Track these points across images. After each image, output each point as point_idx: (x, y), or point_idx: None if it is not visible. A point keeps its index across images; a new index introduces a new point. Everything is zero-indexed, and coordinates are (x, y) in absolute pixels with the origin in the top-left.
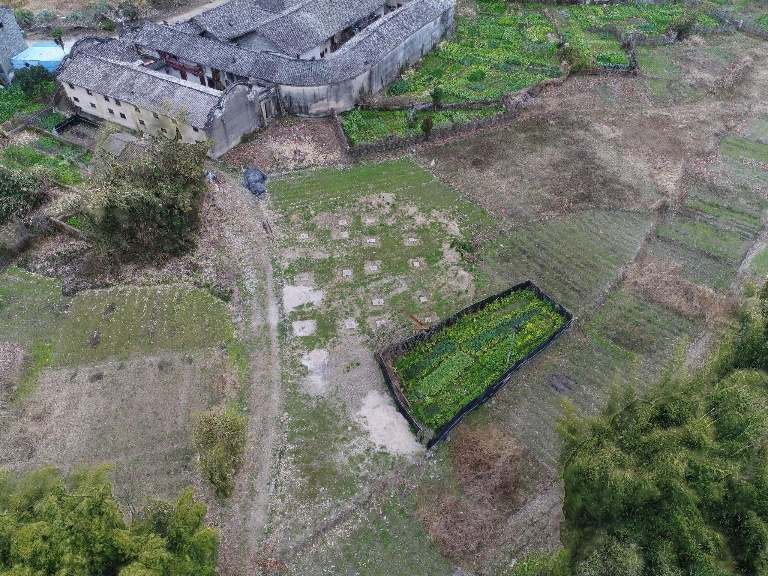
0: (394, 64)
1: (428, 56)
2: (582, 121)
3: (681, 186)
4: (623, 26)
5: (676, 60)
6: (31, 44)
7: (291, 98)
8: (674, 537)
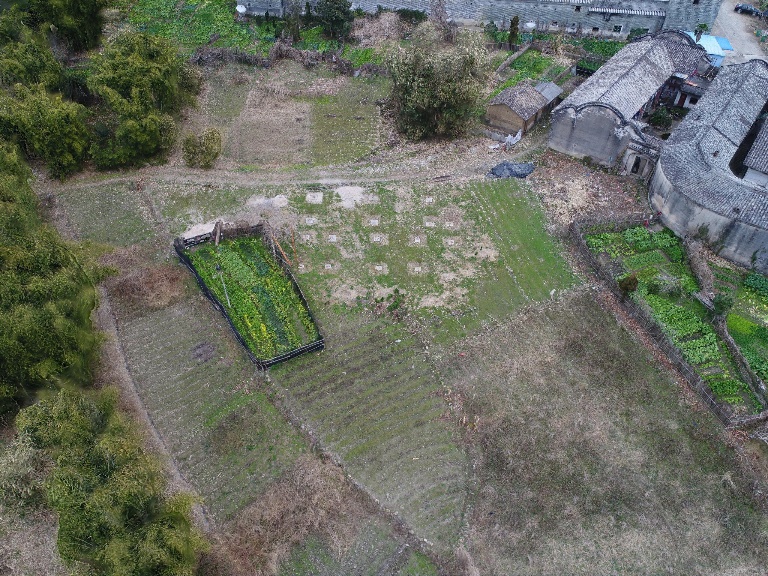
0: None
1: None
2: (761, 544)
3: None
4: None
5: None
6: (749, 46)
7: (655, 173)
8: None
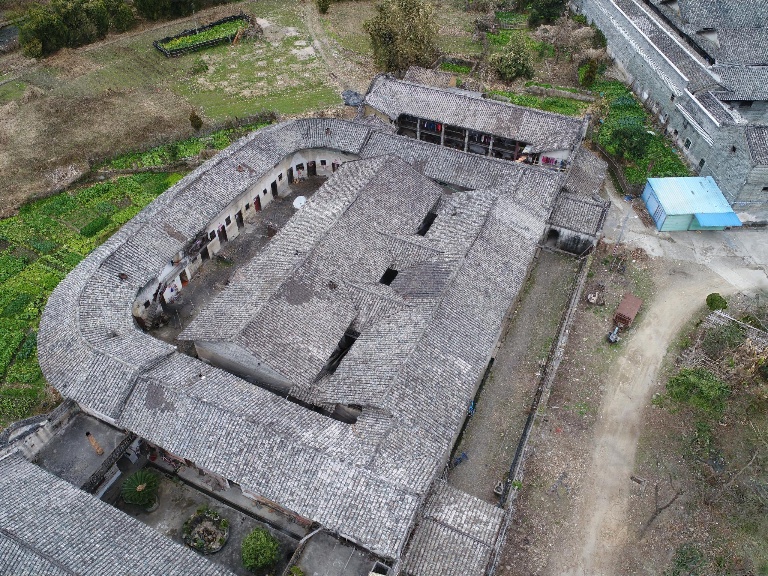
0: None
1: None
2: None
3: None
4: None
5: None
6: None
7: None
8: None
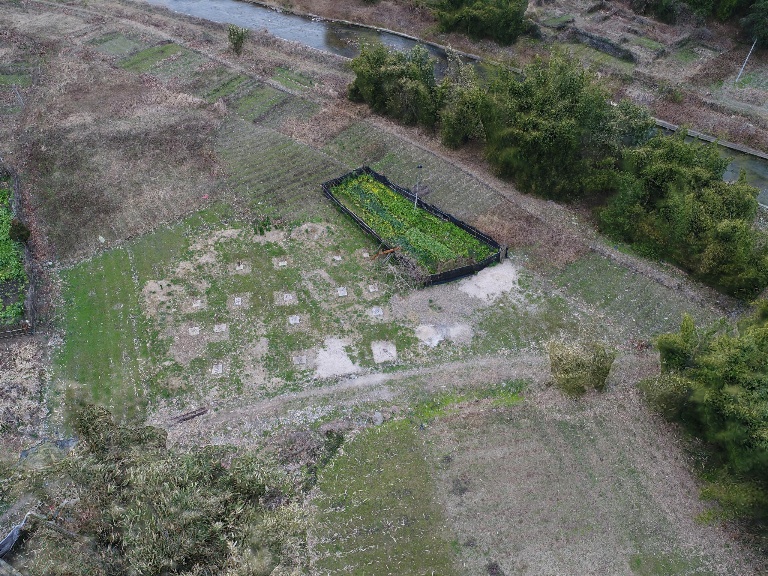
0: None
1: None
2: (49, 131)
3: None
4: None
5: None
6: None
7: None
8: None
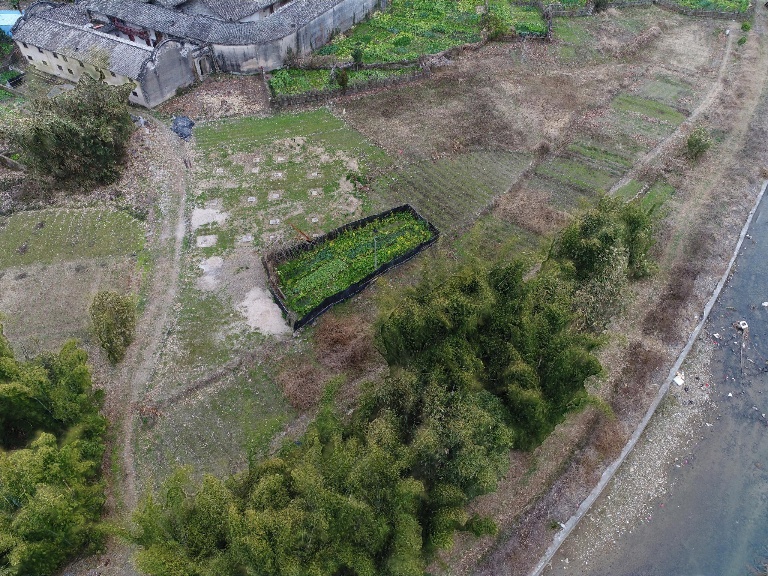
0: (323, 29)
1: (360, 24)
2: (490, 80)
3: (567, 134)
4: (549, 0)
5: (590, 29)
6: None
7: (223, 57)
8: (446, 362)
